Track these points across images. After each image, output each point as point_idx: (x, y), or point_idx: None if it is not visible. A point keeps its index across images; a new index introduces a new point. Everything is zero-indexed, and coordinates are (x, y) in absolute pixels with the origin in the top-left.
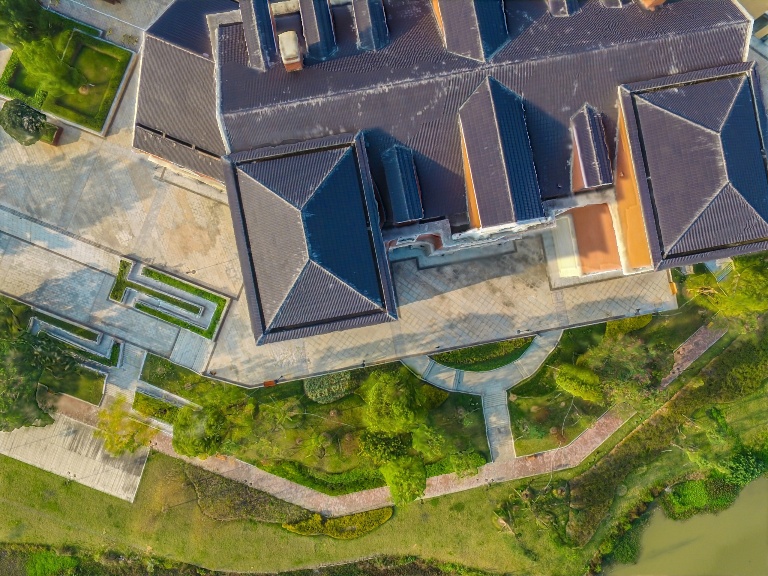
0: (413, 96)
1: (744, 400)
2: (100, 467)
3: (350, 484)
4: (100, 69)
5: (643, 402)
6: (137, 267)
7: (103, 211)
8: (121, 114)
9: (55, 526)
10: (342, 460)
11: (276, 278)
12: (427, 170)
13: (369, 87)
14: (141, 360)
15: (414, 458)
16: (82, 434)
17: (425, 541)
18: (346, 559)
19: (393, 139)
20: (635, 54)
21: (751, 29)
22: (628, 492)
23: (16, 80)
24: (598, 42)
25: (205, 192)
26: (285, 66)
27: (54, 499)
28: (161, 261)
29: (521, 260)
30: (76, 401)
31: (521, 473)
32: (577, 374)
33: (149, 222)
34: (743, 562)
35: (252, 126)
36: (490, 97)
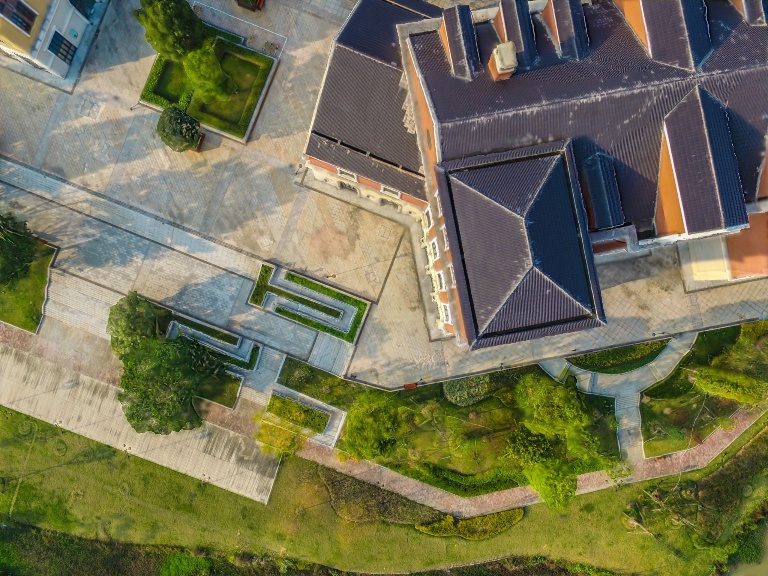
0: (623, 105)
1: None
2: (234, 469)
3: (483, 485)
4: (242, 76)
5: None
6: (278, 271)
7: (244, 216)
8: (261, 120)
9: (190, 528)
10: (477, 462)
11: (493, 284)
12: (623, 177)
13: (583, 96)
14: (278, 363)
15: (561, 460)
16: (216, 437)
17: (555, 542)
18: (477, 560)
19: (597, 147)
20: None
21: None
22: (753, 493)
23: (159, 87)
24: None
25: (344, 197)
26: (497, 76)
27: (189, 501)
28: (302, 265)
29: (656, 264)
30: (210, 404)
31: (650, 474)
32: (727, 377)
33: (290, 227)
34: None
35: (467, 135)
36: (699, 106)
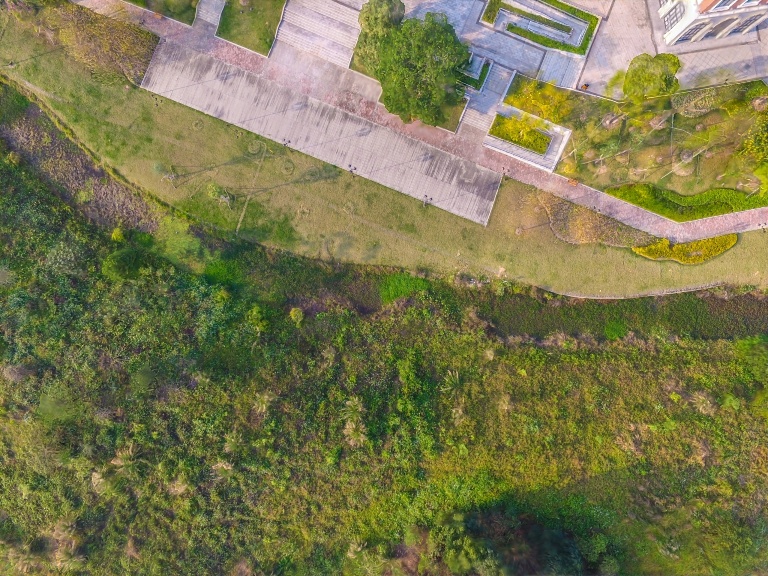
0: None
1: None
2: (455, 191)
3: (700, 208)
4: None
5: None
6: None
7: None
8: None
9: (411, 248)
10: (698, 180)
11: None
12: None
13: None
14: (504, 83)
15: None
16: (438, 160)
17: (767, 268)
18: (689, 286)
19: None
20: None
21: None
22: None
23: None
24: None
25: None
26: None
27: (411, 221)
28: None
29: None
30: (433, 128)
31: None
32: None
33: None
34: None
35: None
36: None
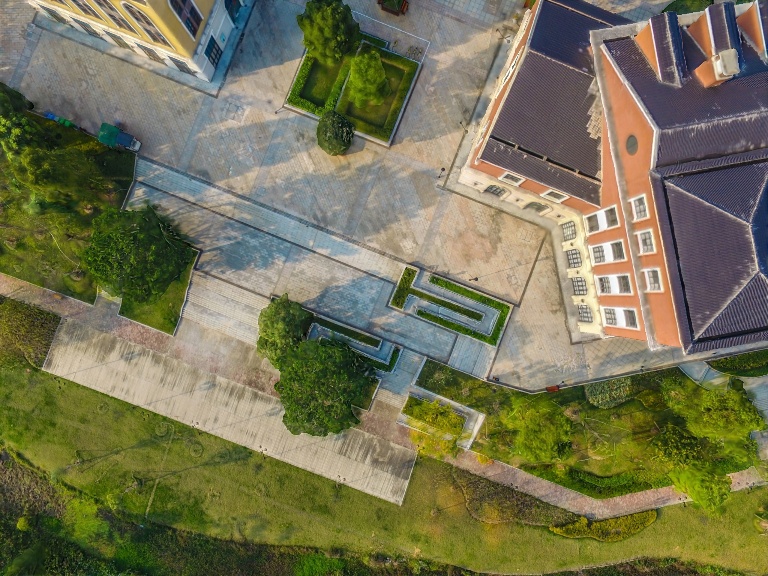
0: None
1: None
2: (369, 471)
3: (618, 487)
4: None
5: None
6: (421, 274)
7: (387, 219)
8: (404, 124)
9: (325, 529)
10: (615, 464)
11: (712, 289)
12: None
13: None
14: (416, 366)
15: (711, 462)
16: (351, 438)
17: (687, 543)
18: (609, 561)
19: None
20: None
21: None
22: None
23: (304, 91)
24: None
25: (487, 201)
26: (713, 82)
27: (324, 502)
28: (444, 268)
29: None
30: None
31: None
32: None
33: (432, 230)
34: None
35: (684, 141)
36: None
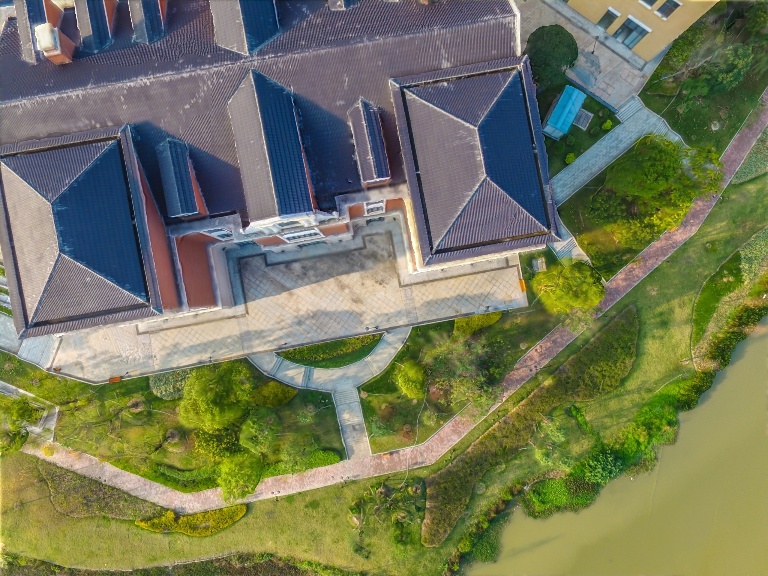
0: (177, 89)
1: (604, 398)
2: None
3: (202, 481)
4: None
5: (476, 399)
6: None
7: None
8: None
9: None
10: (192, 457)
11: (34, 272)
12: (207, 164)
13: (129, 80)
14: None
15: (250, 455)
16: None
17: (280, 539)
18: (201, 556)
19: (165, 133)
20: (402, 48)
21: (519, 23)
22: (487, 490)
23: None
24: (364, 36)
25: None
26: (49, 59)
27: None
28: None
29: (370, 257)
30: None
31: (377, 471)
32: (408, 371)
33: None
34: (604, 561)
35: (13, 119)
36: (254, 90)
